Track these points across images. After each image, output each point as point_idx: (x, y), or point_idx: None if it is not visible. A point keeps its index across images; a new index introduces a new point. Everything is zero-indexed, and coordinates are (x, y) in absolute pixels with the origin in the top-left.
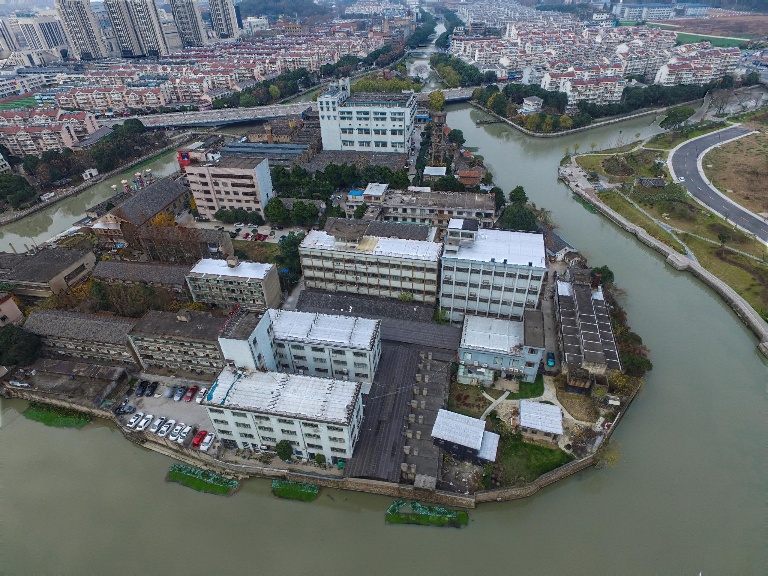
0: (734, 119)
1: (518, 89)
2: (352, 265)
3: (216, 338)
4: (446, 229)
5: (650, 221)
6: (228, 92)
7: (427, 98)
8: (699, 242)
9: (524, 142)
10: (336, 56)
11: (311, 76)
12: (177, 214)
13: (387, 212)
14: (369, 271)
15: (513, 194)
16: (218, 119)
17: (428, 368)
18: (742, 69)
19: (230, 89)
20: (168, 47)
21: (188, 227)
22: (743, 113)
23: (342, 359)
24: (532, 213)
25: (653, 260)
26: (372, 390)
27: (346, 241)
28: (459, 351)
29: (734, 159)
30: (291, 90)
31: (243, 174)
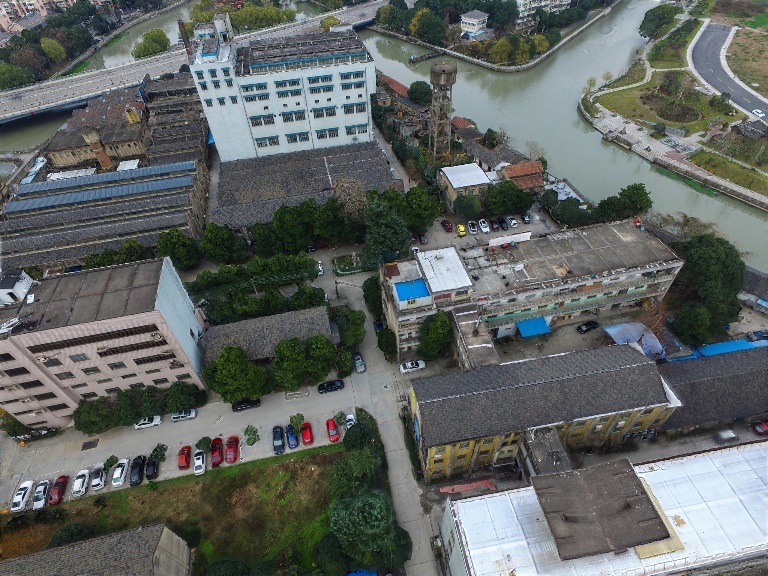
0: (698, 14)
1: (441, 2)
2: None
3: None
4: None
5: None
6: None
7: (314, 30)
8: None
9: (484, 81)
10: None
11: (104, 13)
12: None
13: (480, 310)
14: None
15: (630, 200)
16: None
17: None
18: None
19: None
20: None
21: (8, 474)
22: (696, 4)
23: None
24: None
25: None
26: None
27: None
28: None
29: (767, 70)
30: (81, 42)
31: (126, 327)
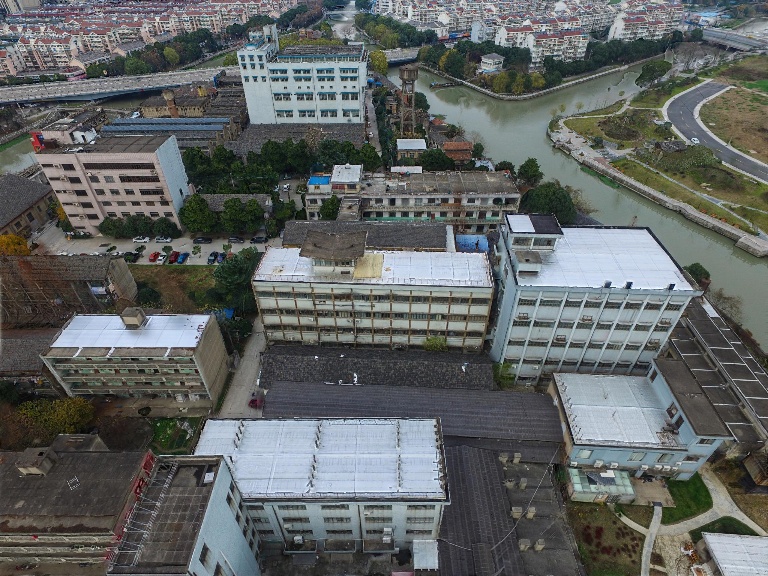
0: (703, 74)
1: (471, 46)
2: (347, 302)
3: (111, 511)
4: (510, 234)
5: (693, 194)
6: (107, 56)
7: None
8: (764, 217)
9: (489, 107)
10: (244, 15)
11: (216, 38)
12: (37, 229)
13: (367, 206)
14: (375, 309)
15: (524, 169)
16: (96, 90)
17: (523, 486)
18: (684, 25)
19: (110, 53)
20: (20, 5)
21: (56, 249)
22: (708, 68)
23: (383, 515)
24: (569, 194)
25: (704, 243)
26: (443, 558)
27: (333, 264)
28: (571, 449)
29: (732, 116)
30: (193, 54)
31: (137, 161)
